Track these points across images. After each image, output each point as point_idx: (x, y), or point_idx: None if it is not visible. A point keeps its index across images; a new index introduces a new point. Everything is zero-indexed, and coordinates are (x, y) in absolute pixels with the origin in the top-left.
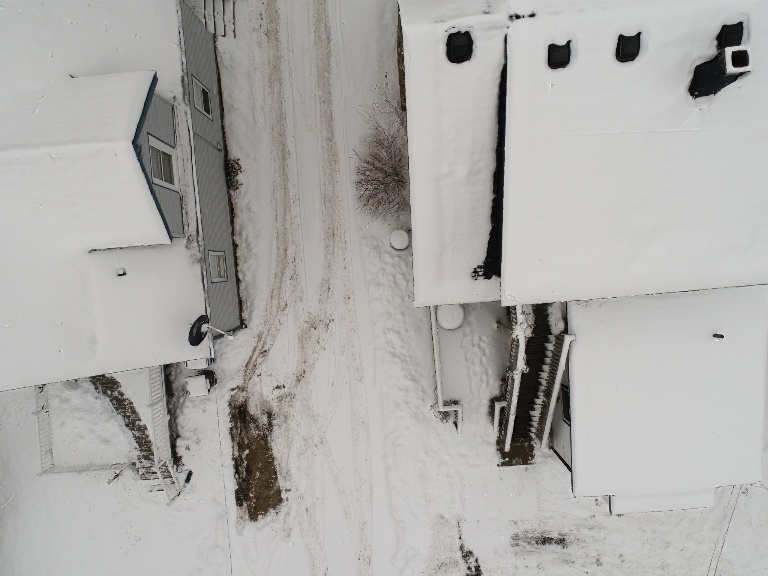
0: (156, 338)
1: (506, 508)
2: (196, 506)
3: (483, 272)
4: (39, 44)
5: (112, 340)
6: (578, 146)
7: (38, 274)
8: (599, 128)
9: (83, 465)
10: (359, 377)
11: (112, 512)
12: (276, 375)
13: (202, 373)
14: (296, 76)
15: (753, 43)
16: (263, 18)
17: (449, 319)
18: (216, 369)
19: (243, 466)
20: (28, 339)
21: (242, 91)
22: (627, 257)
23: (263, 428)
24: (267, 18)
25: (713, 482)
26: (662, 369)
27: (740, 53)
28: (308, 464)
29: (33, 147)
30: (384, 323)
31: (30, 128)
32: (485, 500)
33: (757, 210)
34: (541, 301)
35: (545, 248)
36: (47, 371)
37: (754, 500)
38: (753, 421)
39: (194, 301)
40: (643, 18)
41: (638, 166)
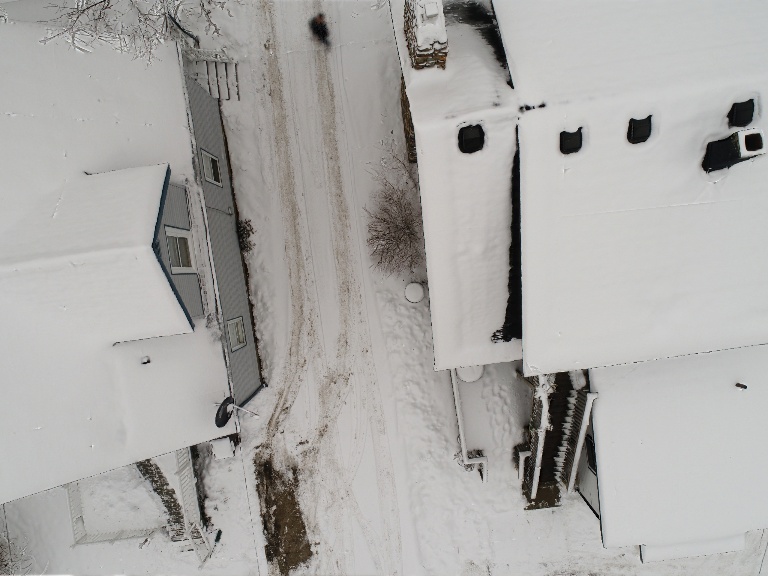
0: (183, 421)
1: (535, 551)
2: (227, 563)
3: (502, 335)
4: (53, 145)
5: (140, 429)
6: (594, 225)
7: (65, 373)
8: (614, 207)
9: (114, 532)
10: (381, 429)
11: (145, 574)
12: (299, 431)
13: None
14: (302, 134)
15: (765, 119)
16: (266, 78)
17: (469, 372)
18: None
19: (271, 522)
20: (60, 438)
21: (249, 153)
22: (647, 324)
23: (289, 484)
24: (270, 78)
25: (743, 527)
26: (686, 420)
27: (753, 136)
28: (336, 517)
29: (55, 256)
30: (403, 375)
31: (50, 234)
32: (514, 544)
33: None
34: (563, 370)
35: (565, 321)
36: (80, 468)
37: None
38: None
39: (217, 379)
40: (653, 102)
41: (654, 239)
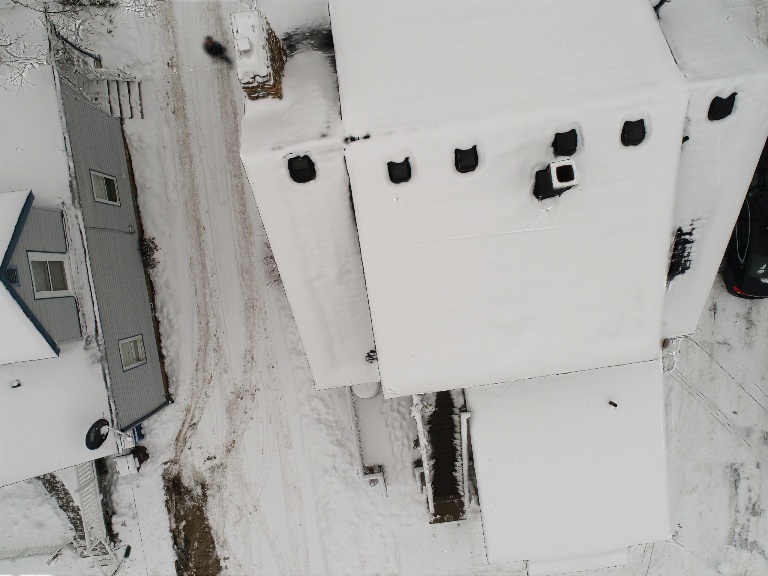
0: (57, 443)
1: (441, 564)
2: None
3: None
4: None
5: (9, 452)
6: (433, 251)
7: None
8: (450, 234)
9: (20, 549)
10: (288, 444)
11: None
12: (206, 447)
13: (133, 450)
14: (205, 152)
15: (588, 148)
16: (169, 97)
17: (363, 389)
18: (147, 444)
19: (181, 537)
20: None
21: (153, 170)
22: (499, 347)
23: (198, 499)
24: (173, 96)
25: (623, 543)
26: (562, 438)
27: (565, 167)
28: (244, 532)
29: None
30: (308, 390)
31: None
32: (420, 557)
33: (620, 297)
34: (422, 392)
35: (417, 345)
36: None
37: (684, 542)
38: (657, 482)
39: (96, 401)
40: (475, 133)
41: (495, 265)
